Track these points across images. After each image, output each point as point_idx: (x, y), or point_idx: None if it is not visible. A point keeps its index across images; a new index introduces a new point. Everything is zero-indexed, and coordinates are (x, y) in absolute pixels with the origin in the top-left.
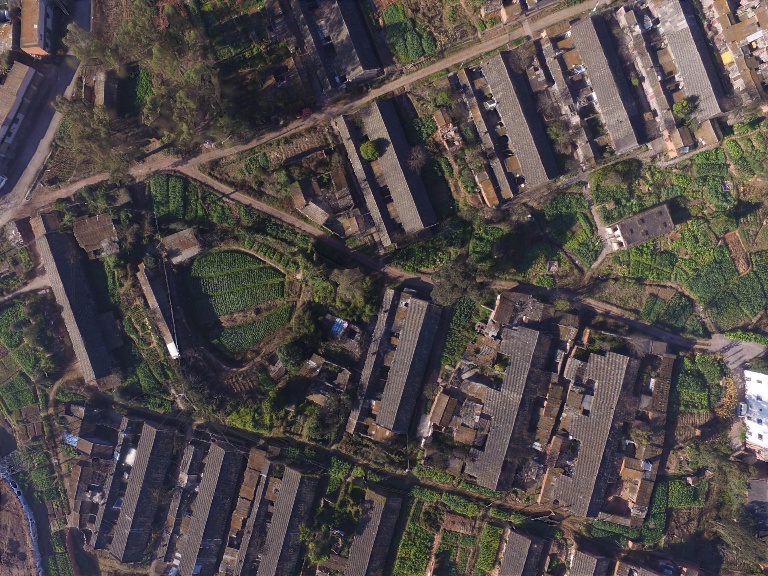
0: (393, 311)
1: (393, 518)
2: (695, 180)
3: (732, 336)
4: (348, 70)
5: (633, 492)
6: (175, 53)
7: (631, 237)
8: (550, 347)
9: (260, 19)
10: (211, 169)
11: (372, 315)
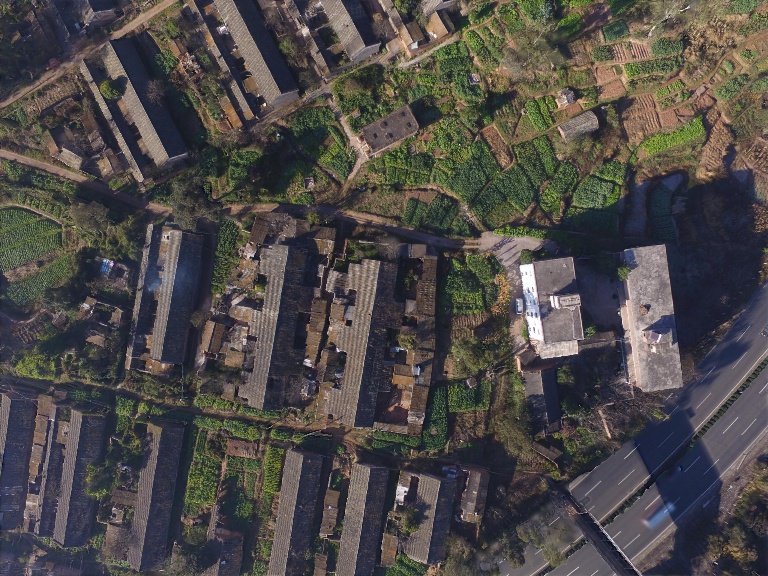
0: (156, 245)
1: (175, 448)
2: (439, 77)
3: (501, 232)
4: (83, 15)
5: (408, 399)
6: None
7: (376, 142)
8: (315, 264)
9: None
10: None
11: (139, 252)
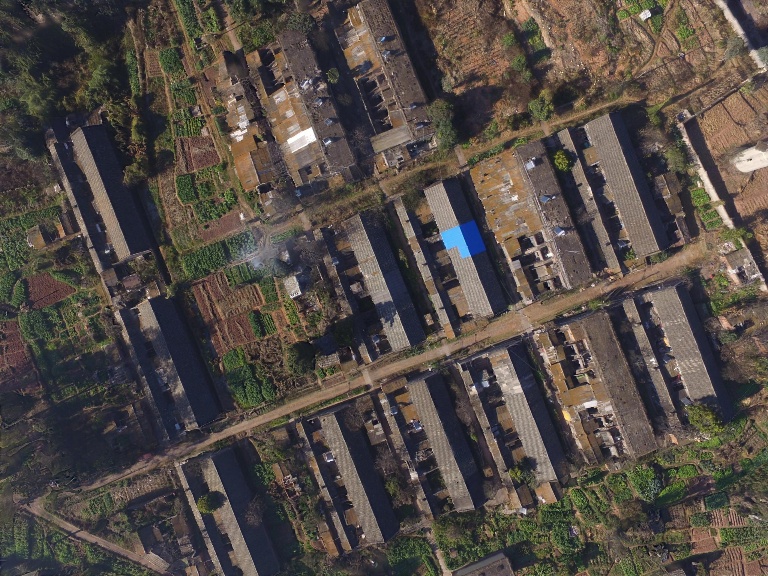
0: None
1: None
2: (540, 528)
3: None
4: (186, 422)
5: None
6: (4, 424)
7: None
8: None
9: (103, 358)
10: (56, 509)
11: None
